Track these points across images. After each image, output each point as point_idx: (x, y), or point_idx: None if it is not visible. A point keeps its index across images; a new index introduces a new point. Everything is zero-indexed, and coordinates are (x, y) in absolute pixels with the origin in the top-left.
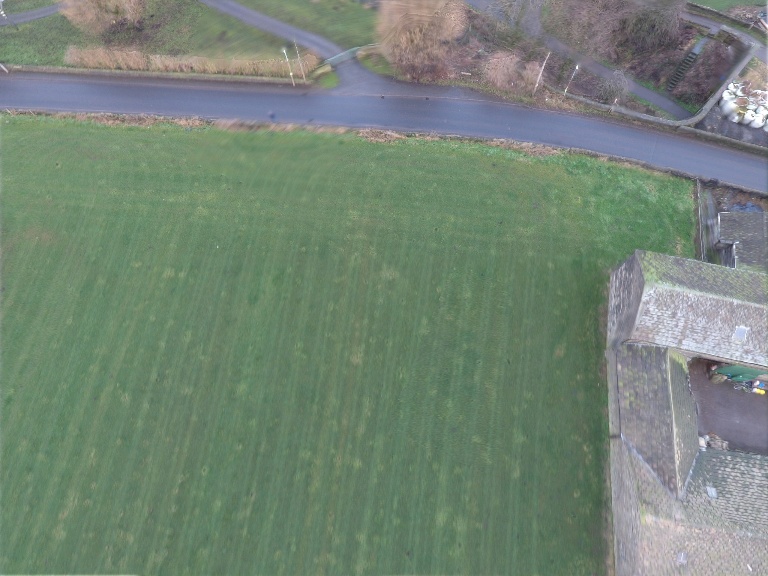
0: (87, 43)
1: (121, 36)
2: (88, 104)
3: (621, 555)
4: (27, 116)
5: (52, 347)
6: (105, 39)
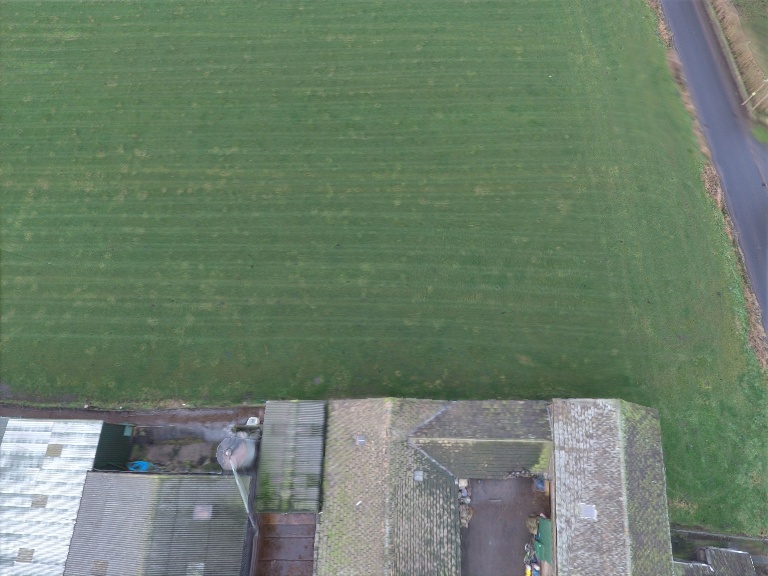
0: None
1: None
2: None
3: None
4: None
5: None
6: None
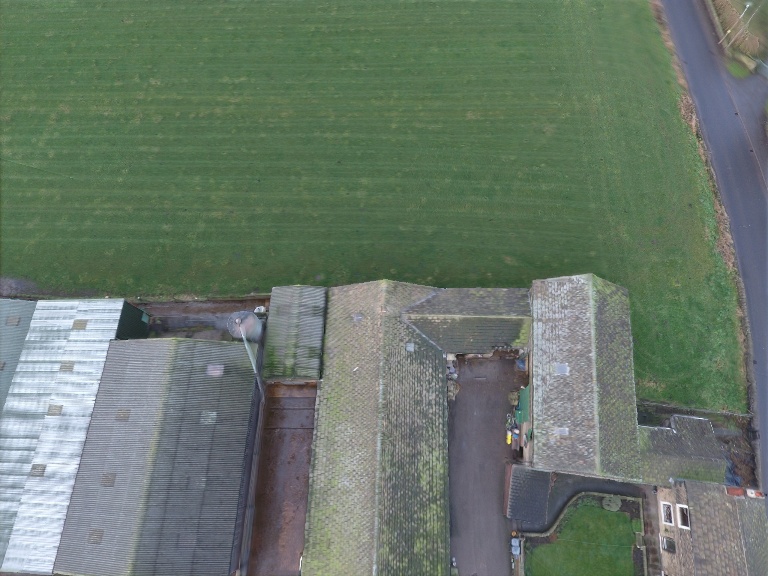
0: None
1: None
2: None
3: None
4: None
5: None
6: None
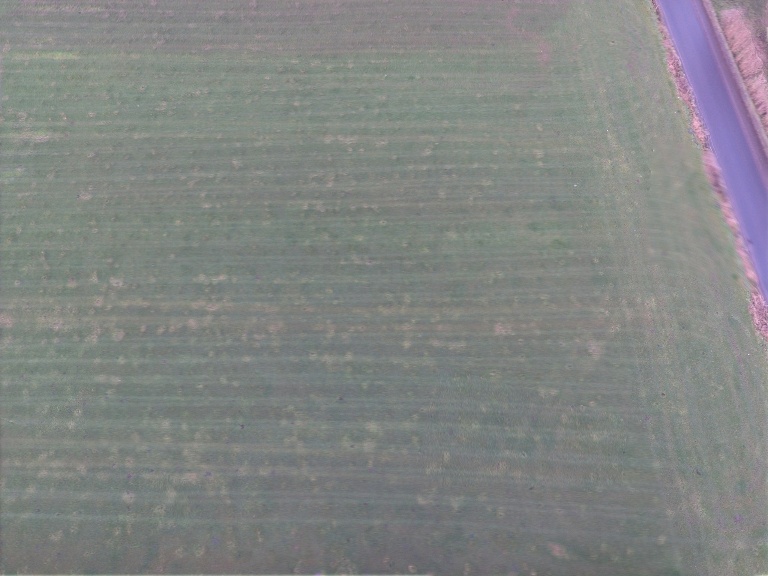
0: (751, 23)
1: None
2: (683, 45)
3: None
4: (652, 6)
5: (456, 91)
6: (763, 35)
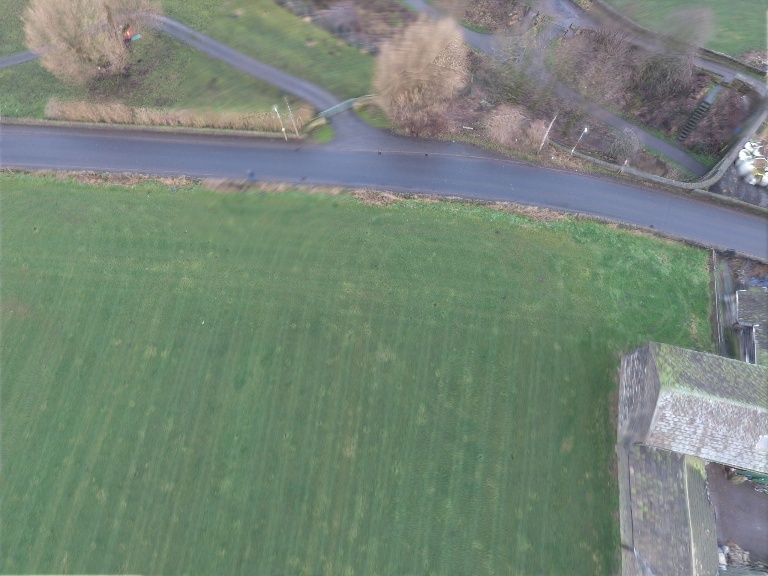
0: (71, 91)
1: (106, 83)
2: (70, 160)
3: None
4: (5, 174)
5: (24, 436)
6: (90, 86)
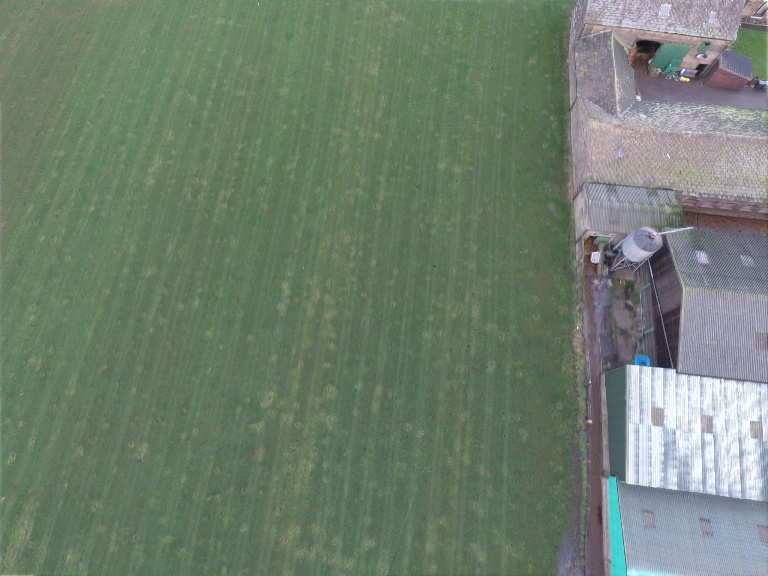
0: None
1: None
2: None
3: (577, 173)
4: None
5: (132, 68)
6: None
